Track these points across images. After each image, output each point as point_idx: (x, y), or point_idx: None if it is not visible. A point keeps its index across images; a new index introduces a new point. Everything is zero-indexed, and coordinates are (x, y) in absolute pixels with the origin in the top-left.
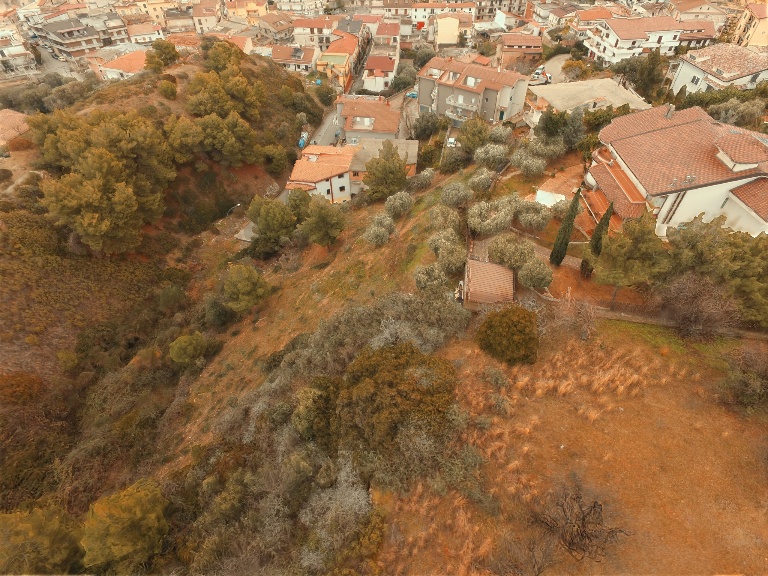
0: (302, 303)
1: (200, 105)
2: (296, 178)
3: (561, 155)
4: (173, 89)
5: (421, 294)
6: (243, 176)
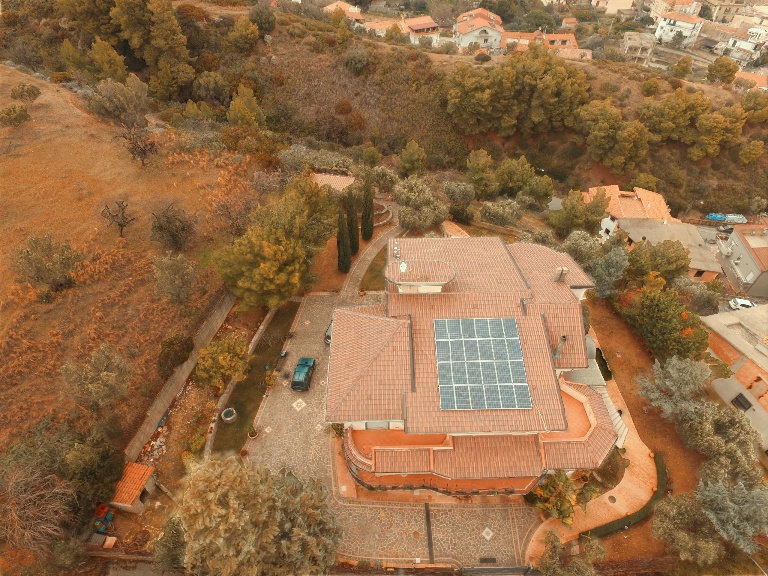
0: None
1: (647, 108)
2: (591, 191)
3: (601, 301)
4: (652, 87)
5: None
6: (596, 172)
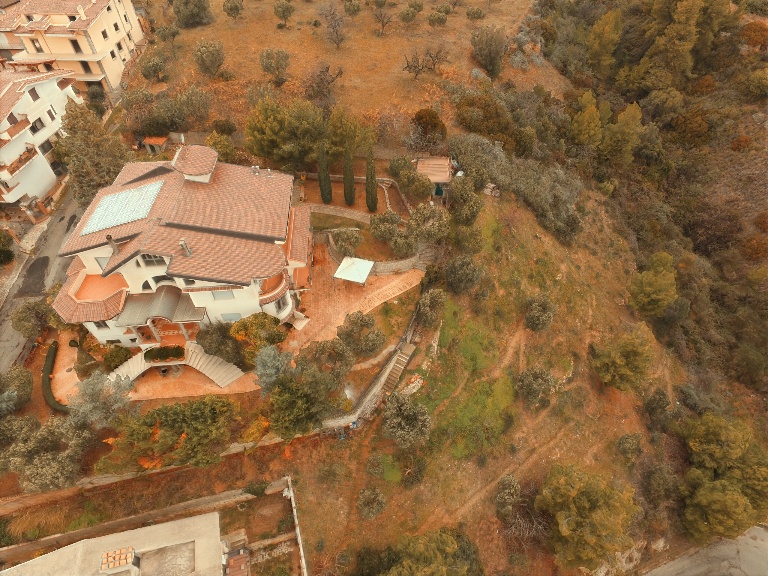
0: (588, 289)
1: None
2: None
3: None
4: None
5: None
6: None
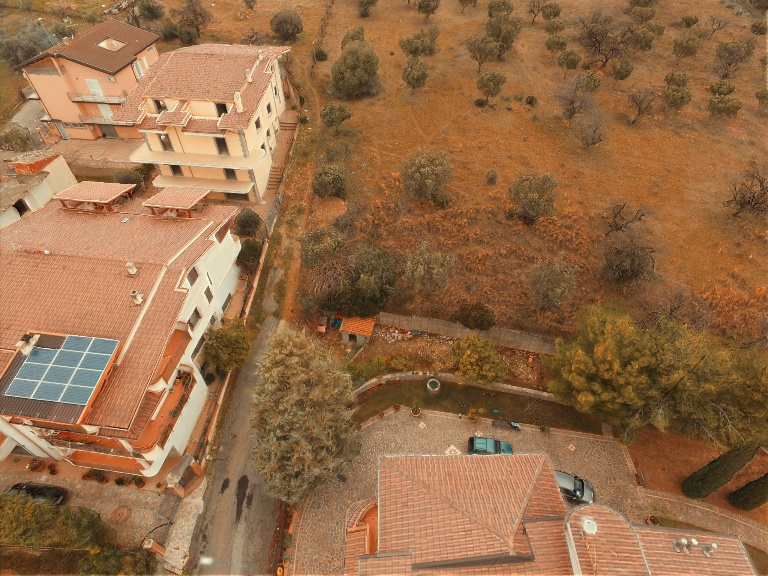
0: None
1: None
2: None
3: None
4: None
5: None
6: None
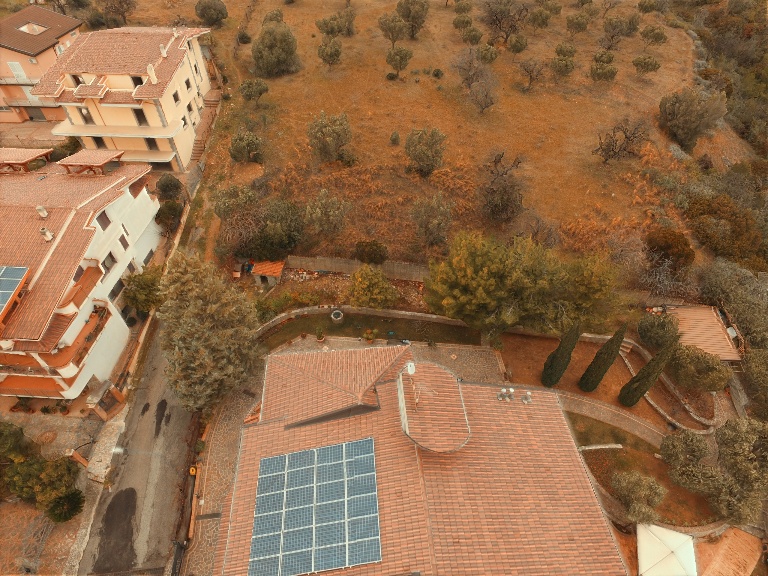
0: None
1: None
2: None
3: None
4: None
5: (763, 319)
6: None
